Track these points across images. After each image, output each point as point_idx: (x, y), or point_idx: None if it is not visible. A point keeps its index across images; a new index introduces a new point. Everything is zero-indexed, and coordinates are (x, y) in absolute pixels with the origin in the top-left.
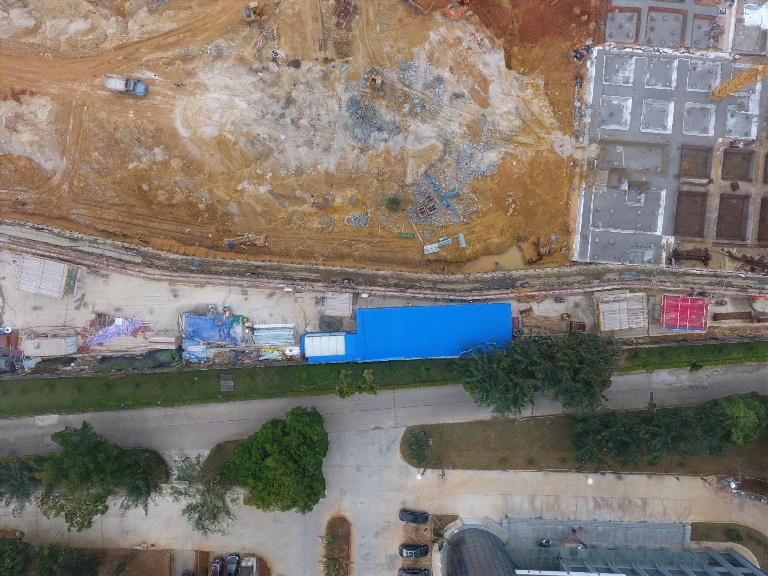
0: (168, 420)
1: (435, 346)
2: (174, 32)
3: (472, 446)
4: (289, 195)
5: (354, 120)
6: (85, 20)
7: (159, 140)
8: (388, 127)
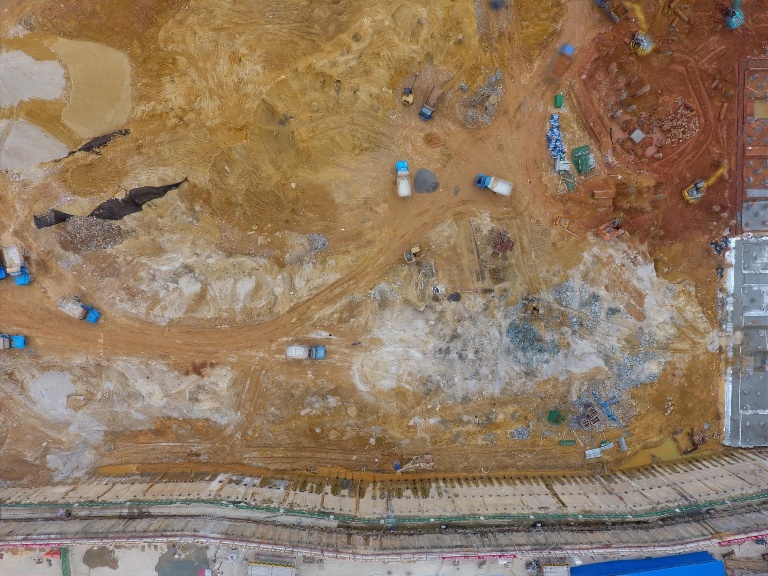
0: None
1: None
2: (338, 282)
3: None
4: (454, 419)
5: (515, 345)
6: (249, 278)
7: (334, 391)
8: (548, 347)
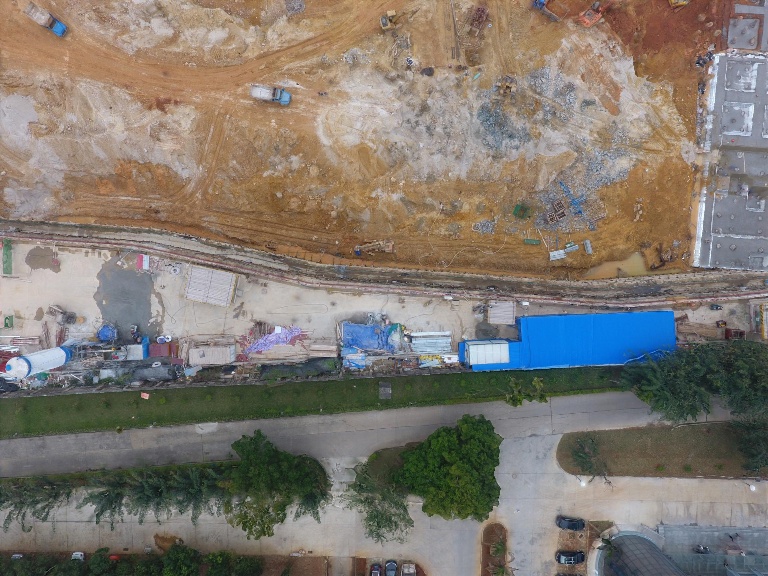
0: (327, 428)
1: (598, 354)
2: (311, 41)
3: (628, 453)
4: (418, 202)
5: (486, 127)
6: (223, 29)
7: (297, 148)
8: (519, 134)
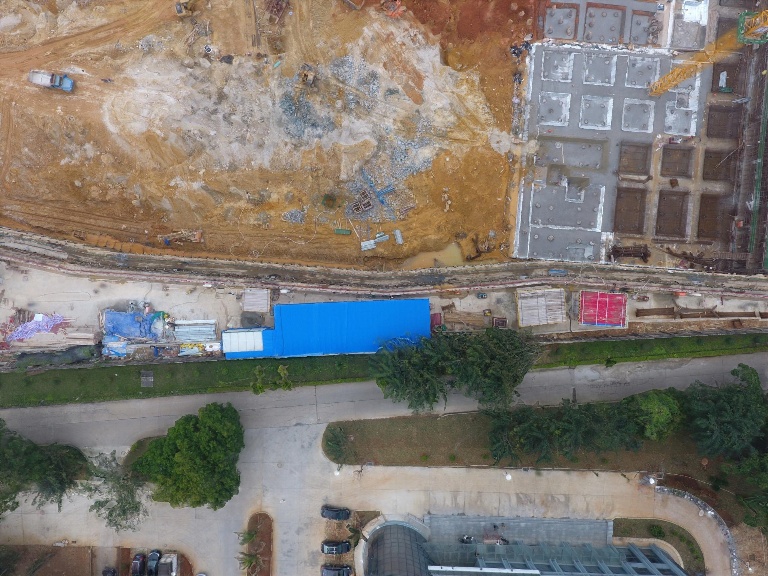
0: (88, 416)
1: (353, 342)
2: (104, 27)
3: (394, 442)
4: (224, 191)
5: (288, 116)
6: (15, 15)
7: (89, 136)
8: (322, 123)
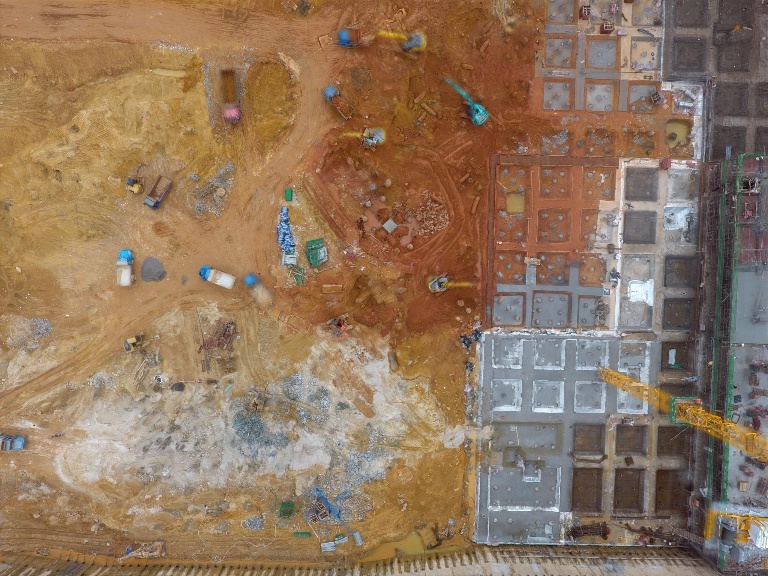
0: None
1: None
2: (55, 370)
3: None
4: (182, 508)
5: (241, 436)
6: None
7: (44, 479)
8: (275, 439)
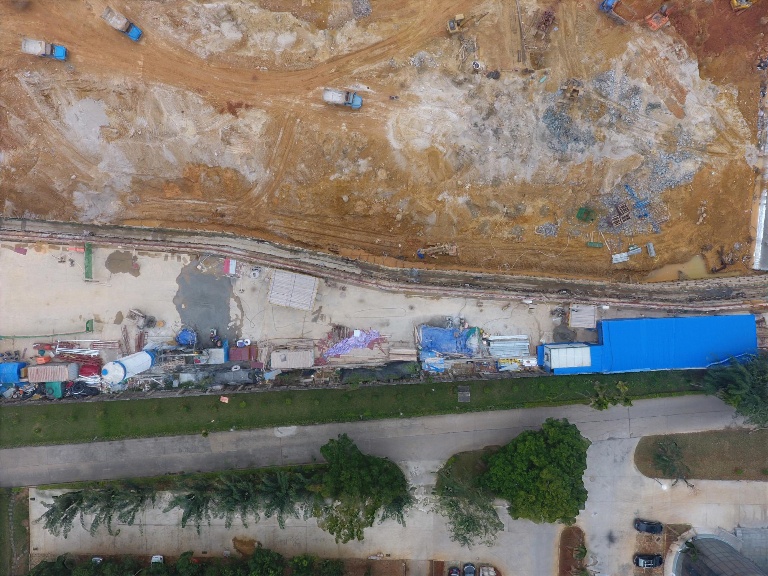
0: (405, 431)
1: (680, 357)
2: (379, 44)
3: (706, 456)
4: (483, 205)
5: (551, 131)
6: (291, 33)
7: (366, 152)
8: (584, 137)
